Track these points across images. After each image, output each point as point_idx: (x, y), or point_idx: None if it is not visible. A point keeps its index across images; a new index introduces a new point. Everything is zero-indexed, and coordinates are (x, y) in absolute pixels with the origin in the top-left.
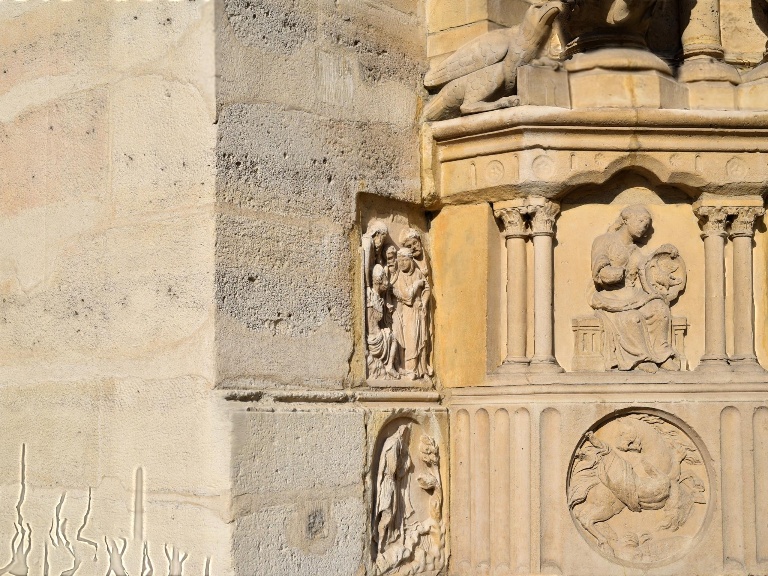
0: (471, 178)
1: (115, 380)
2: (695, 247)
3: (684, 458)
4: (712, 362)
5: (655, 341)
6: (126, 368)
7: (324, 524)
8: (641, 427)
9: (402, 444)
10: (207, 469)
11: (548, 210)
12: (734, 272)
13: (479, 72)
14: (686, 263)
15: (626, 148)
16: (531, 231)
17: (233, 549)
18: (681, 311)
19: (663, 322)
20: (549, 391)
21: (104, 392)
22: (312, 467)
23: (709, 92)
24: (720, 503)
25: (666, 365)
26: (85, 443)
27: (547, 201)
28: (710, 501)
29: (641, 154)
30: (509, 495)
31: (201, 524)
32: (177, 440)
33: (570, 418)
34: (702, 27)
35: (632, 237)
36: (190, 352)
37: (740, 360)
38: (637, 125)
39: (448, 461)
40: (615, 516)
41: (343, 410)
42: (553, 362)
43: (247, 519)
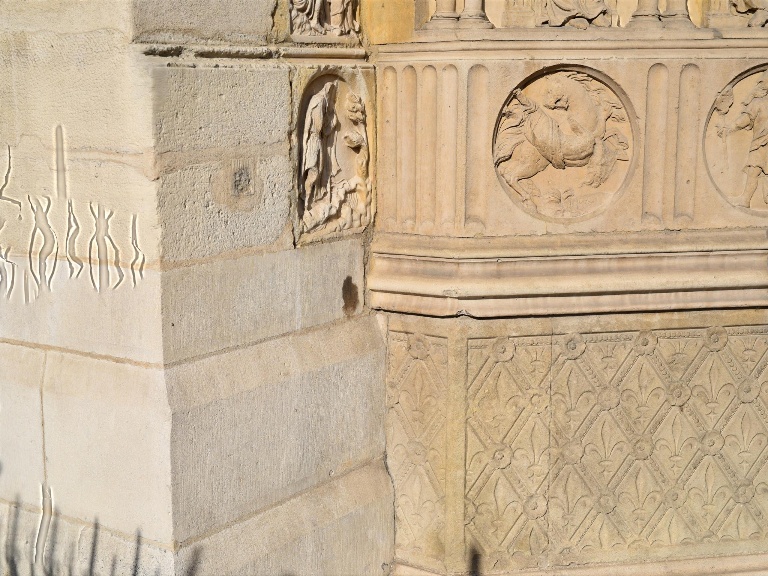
0: None
1: (27, 34)
2: None
3: (610, 116)
4: (644, 18)
5: None
6: (37, 21)
7: (250, 182)
8: (569, 84)
9: (328, 102)
10: (129, 126)
11: None
12: None
13: None
14: None
15: None
16: None
17: (159, 206)
18: None
19: None
20: (478, 47)
21: (16, 47)
22: (236, 125)
23: None
24: (642, 160)
25: (597, 21)
26: (0, 101)
27: None
28: (633, 158)
29: None
30: (435, 153)
31: (125, 182)
32: (96, 97)
33: (498, 75)
34: None
35: None
36: (104, 4)
37: (672, 16)
38: None
39: (375, 119)
40: (539, 173)
41: (267, 66)
42: (483, 17)
43: (172, 177)
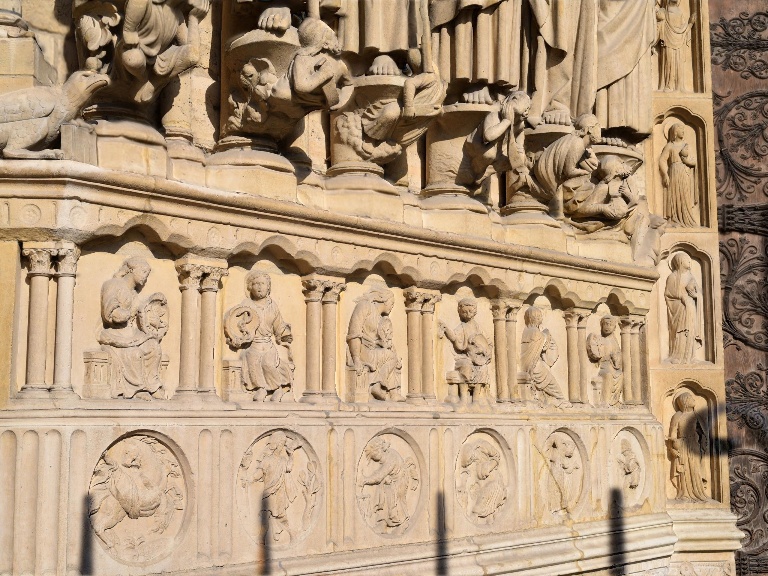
0: (3, 216)
1: None
2: (175, 296)
3: (170, 472)
4: (188, 393)
5: (149, 374)
6: None
7: None
8: (142, 447)
9: None
10: None
11: (75, 254)
12: (202, 319)
13: (25, 122)
14: (169, 309)
15: (142, 209)
16: (55, 271)
17: None
18: (163, 349)
19: (158, 358)
20: (75, 415)
21: None
22: None
23: (189, 169)
24: (197, 508)
25: (157, 394)
26: None
27: (75, 246)
28: (187, 507)
29: (151, 215)
30: (36, 509)
31: None
32: None
33: (94, 439)
34: (182, 114)
35: (136, 284)
36: None
37: (206, 392)
38: (154, 191)
39: None
40: (119, 523)
41: None
42: (72, 389)
43: None
